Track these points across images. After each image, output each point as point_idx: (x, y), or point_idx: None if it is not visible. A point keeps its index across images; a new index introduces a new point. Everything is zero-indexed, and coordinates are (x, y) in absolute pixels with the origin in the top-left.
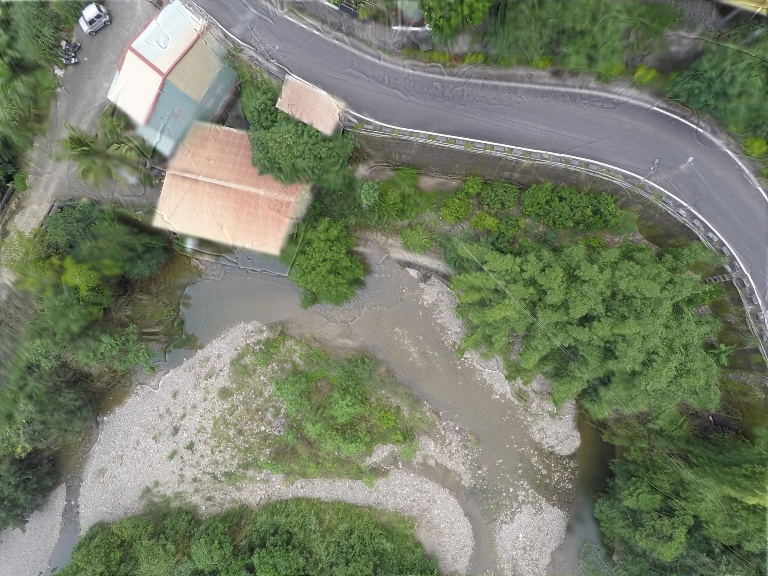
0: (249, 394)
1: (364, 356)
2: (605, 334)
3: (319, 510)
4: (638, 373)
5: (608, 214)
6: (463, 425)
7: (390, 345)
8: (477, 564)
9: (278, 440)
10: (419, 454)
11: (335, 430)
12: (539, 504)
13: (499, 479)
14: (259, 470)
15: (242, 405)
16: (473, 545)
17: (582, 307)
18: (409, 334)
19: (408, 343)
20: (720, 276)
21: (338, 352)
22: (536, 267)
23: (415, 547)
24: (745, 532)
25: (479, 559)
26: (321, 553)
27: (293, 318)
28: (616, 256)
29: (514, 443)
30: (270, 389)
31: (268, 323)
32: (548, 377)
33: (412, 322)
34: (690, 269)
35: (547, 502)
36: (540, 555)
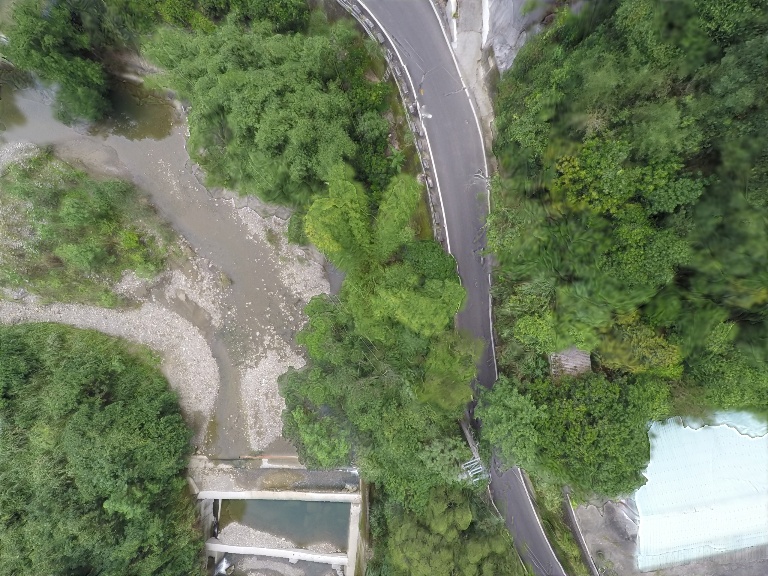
0: (12, 210)
1: (121, 180)
2: (223, 83)
3: (67, 332)
4: (234, 112)
5: (291, 6)
6: (217, 263)
7: (154, 177)
8: (222, 408)
9: (36, 259)
10: (172, 288)
11: (79, 245)
12: (283, 350)
13: (247, 322)
14: (17, 289)
15: (5, 221)
16: (219, 388)
17: (211, 61)
18: (172, 167)
19: (170, 176)
20: (386, 71)
21: (103, 178)
22: (201, 39)
23: (155, 378)
24: (378, 320)
25: (224, 403)
26: (50, 364)
27: (66, 143)
28: (267, 27)
29: (264, 286)
30: (32, 206)
31: (42, 146)
32: (199, 146)
33: (176, 156)
34: (376, 76)
35: (292, 350)
36: (281, 403)
